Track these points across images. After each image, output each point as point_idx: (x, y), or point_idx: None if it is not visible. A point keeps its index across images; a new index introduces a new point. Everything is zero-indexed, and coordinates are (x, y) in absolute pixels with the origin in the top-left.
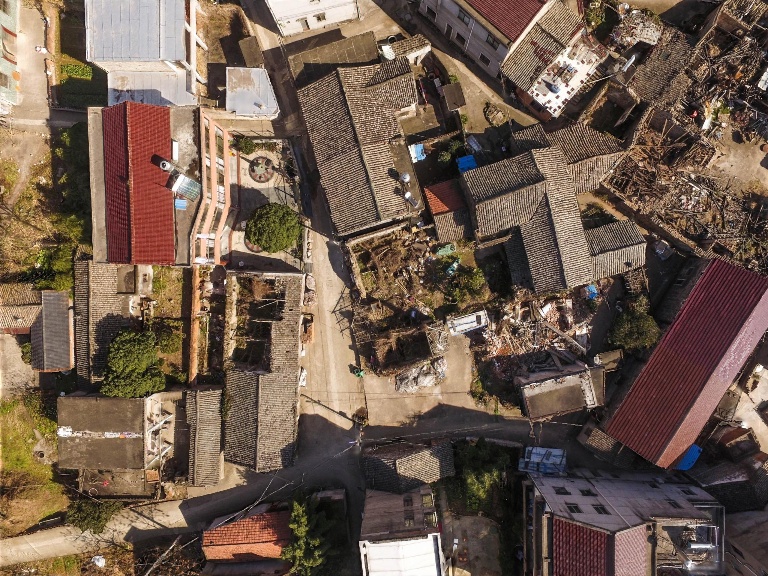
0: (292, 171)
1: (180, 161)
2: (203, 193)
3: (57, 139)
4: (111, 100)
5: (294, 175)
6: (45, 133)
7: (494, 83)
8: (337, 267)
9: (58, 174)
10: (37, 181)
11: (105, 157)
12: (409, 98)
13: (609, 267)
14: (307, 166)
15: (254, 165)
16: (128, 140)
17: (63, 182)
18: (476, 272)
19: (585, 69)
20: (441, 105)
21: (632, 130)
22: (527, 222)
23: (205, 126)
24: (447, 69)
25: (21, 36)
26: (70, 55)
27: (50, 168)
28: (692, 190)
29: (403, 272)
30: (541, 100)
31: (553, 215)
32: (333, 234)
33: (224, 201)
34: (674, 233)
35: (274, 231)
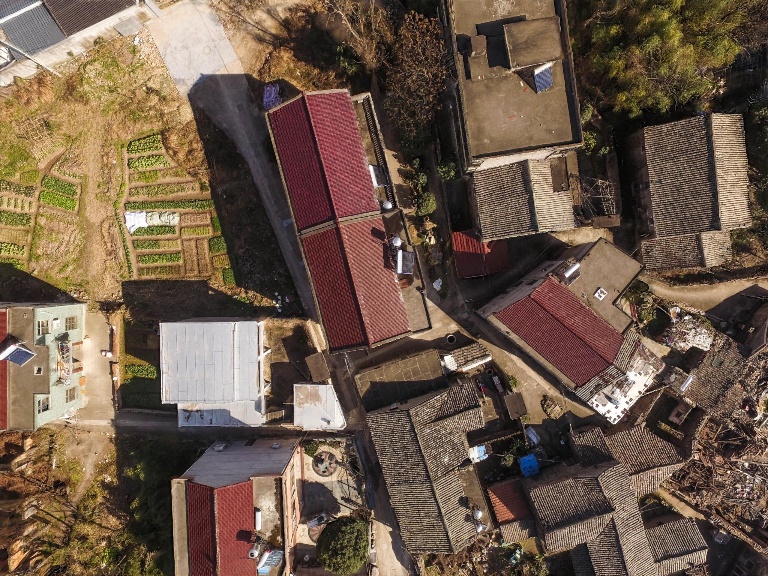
0: (355, 464)
1: (262, 528)
2: (286, 561)
3: (122, 438)
4: (181, 420)
5: (357, 469)
6: (110, 432)
7: (550, 377)
8: (401, 556)
9: (123, 474)
10: (102, 479)
11: (189, 528)
12: (476, 424)
13: (671, 566)
14: (369, 458)
15: (318, 462)
16: (216, 527)
17: (135, 506)
18: (539, 565)
19: (642, 380)
20: (499, 398)
21: (688, 432)
22: (594, 539)
23: (284, 483)
24: (504, 364)
25: (87, 341)
26: (134, 356)
27: (115, 466)
28: (746, 478)
29: (467, 563)
30: (601, 410)
31: (620, 539)
32: (402, 549)
33: (295, 523)
34: (733, 531)
35: (349, 567)
